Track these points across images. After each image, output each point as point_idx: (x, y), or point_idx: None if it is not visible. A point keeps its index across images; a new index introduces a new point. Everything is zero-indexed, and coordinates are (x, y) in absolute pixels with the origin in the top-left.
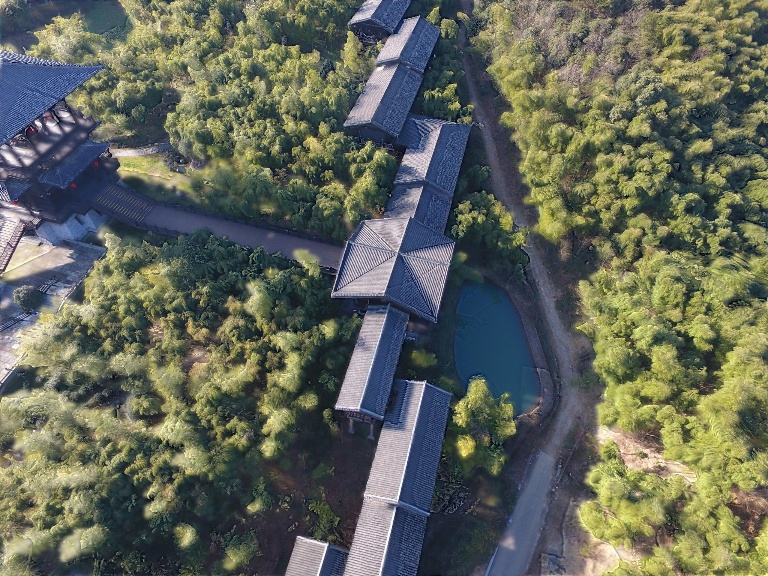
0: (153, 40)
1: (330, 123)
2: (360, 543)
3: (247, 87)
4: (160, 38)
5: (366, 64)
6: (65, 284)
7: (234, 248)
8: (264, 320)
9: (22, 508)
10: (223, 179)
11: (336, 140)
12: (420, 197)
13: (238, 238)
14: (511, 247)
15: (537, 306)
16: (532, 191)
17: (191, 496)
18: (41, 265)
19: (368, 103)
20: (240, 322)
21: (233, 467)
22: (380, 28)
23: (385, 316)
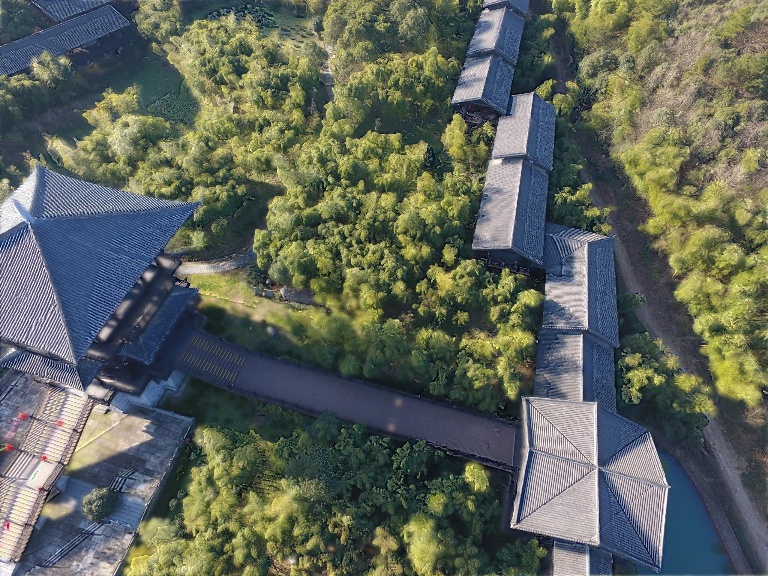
0: (227, 126)
1: (455, 244)
2: None
3: (353, 198)
4: (235, 123)
5: (473, 150)
6: (144, 476)
7: (371, 445)
8: (428, 567)
9: None
10: (338, 330)
11: (469, 271)
12: (582, 352)
13: (358, 406)
14: (691, 411)
15: (723, 486)
16: (698, 327)
17: None
18: (111, 445)
19: (498, 216)
20: (397, 571)
21: None
22: (488, 107)
23: (587, 559)
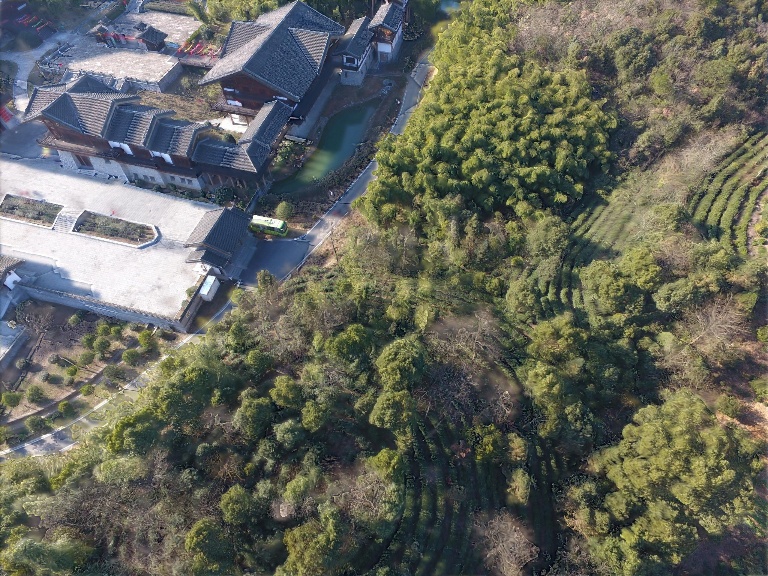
0: None
1: None
2: (378, 13)
3: None
4: None
5: None
6: None
7: None
8: None
9: (248, 3)
10: None
11: None
12: None
13: None
14: None
15: None
16: None
17: (310, 6)
18: None
19: None
20: None
21: (326, 0)
22: None
23: None
